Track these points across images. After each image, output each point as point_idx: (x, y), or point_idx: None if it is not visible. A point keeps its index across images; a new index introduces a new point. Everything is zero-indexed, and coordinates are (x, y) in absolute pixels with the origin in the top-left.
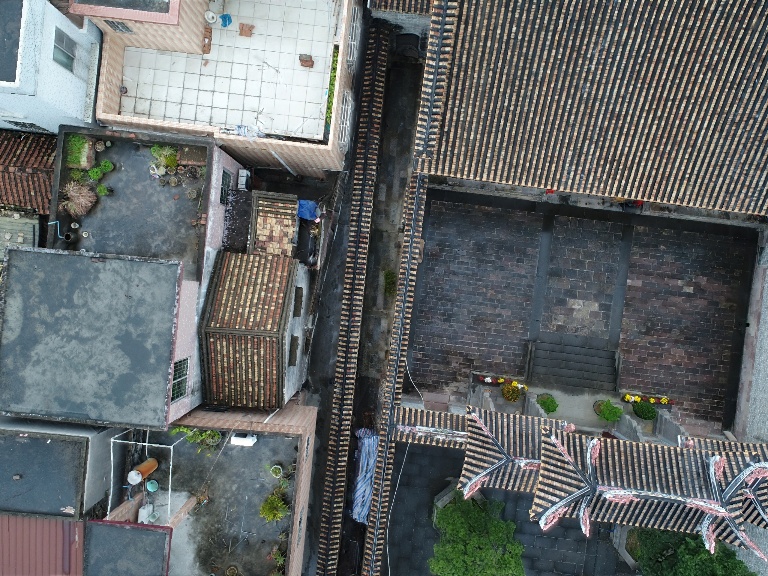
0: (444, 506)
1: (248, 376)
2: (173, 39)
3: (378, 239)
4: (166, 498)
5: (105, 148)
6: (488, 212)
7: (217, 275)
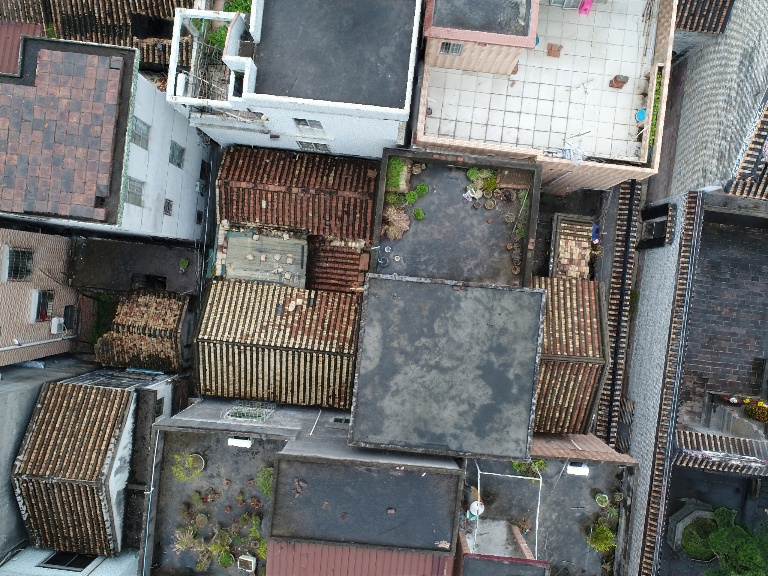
0: (684, 528)
1: (558, 402)
2: (497, 60)
3: None
4: (484, 527)
5: (421, 171)
6: (722, 229)
7: None
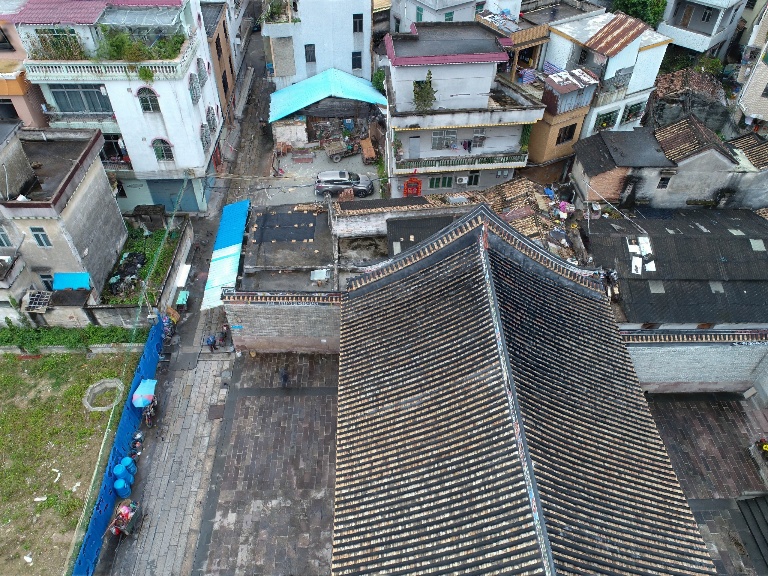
0: None
1: None
2: None
3: None
4: None
5: None
6: None
7: None
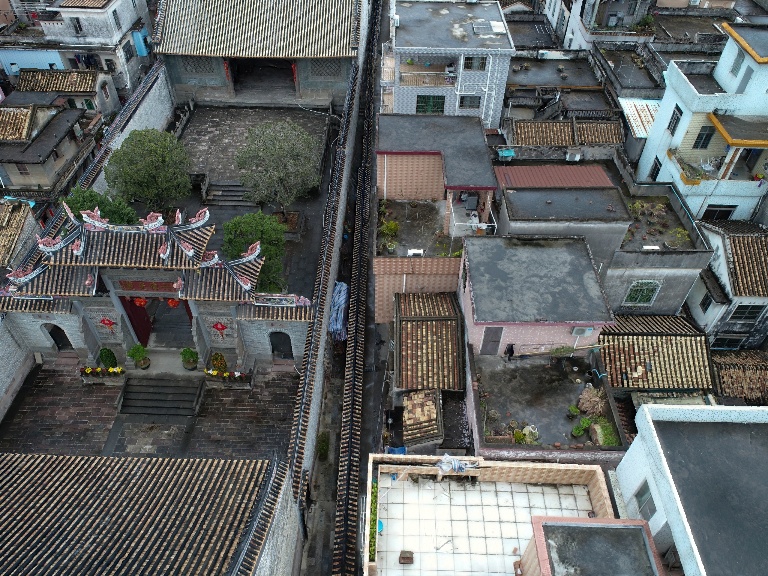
0: None
1: None
2: None
3: (336, 492)
4: None
5: None
6: None
7: (460, 365)
